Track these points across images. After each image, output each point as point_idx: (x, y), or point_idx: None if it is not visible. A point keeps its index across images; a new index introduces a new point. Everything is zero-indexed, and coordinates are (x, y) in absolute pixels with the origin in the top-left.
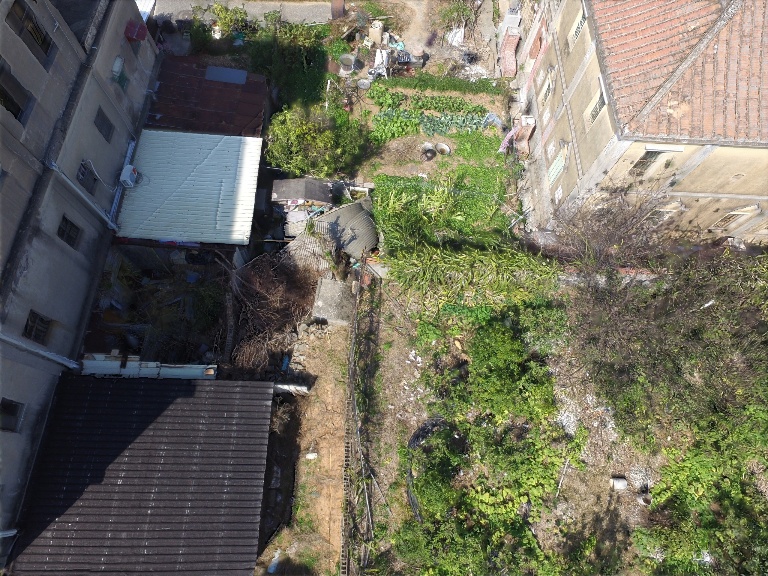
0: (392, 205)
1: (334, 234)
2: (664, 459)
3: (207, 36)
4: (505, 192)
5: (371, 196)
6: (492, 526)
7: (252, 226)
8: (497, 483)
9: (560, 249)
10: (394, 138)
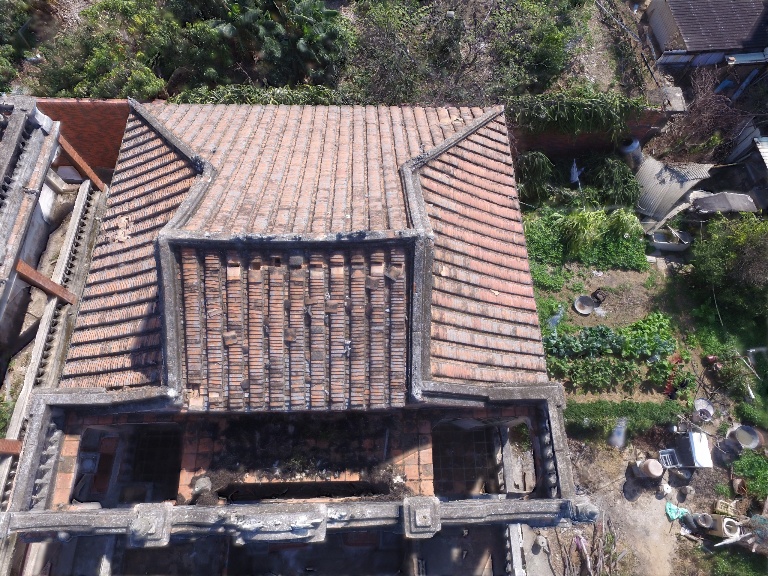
0: None
1: (678, 175)
2: None
3: None
4: None
5: (647, 240)
6: None
7: None
8: None
9: None
10: None
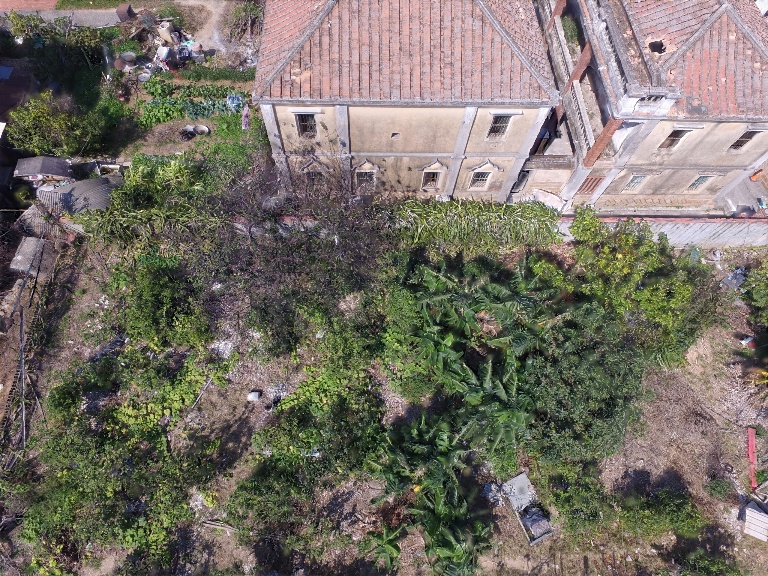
0: (133, 178)
1: (67, 203)
2: (305, 376)
3: (10, 42)
4: (251, 165)
5: None
6: (130, 434)
7: (3, 201)
8: (144, 399)
9: (235, 203)
10: (160, 123)
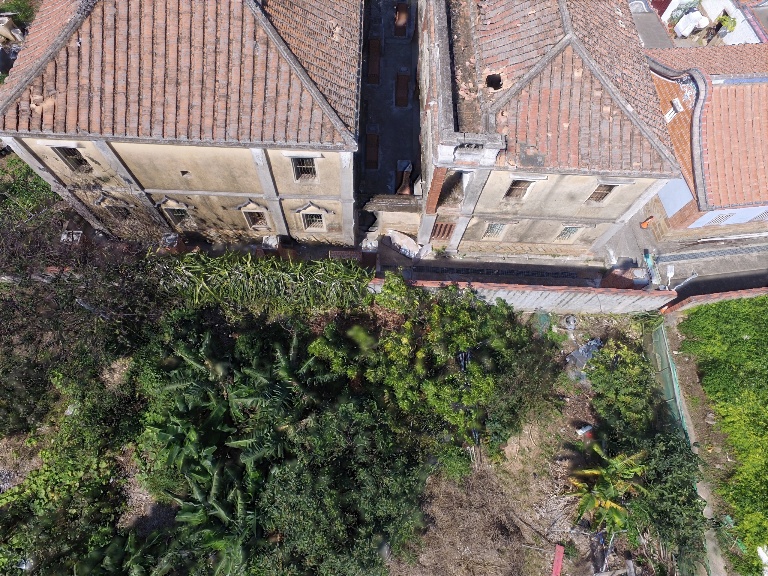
0: None
1: None
2: (39, 463)
3: None
4: None
5: None
6: None
7: None
8: None
9: None
10: None
